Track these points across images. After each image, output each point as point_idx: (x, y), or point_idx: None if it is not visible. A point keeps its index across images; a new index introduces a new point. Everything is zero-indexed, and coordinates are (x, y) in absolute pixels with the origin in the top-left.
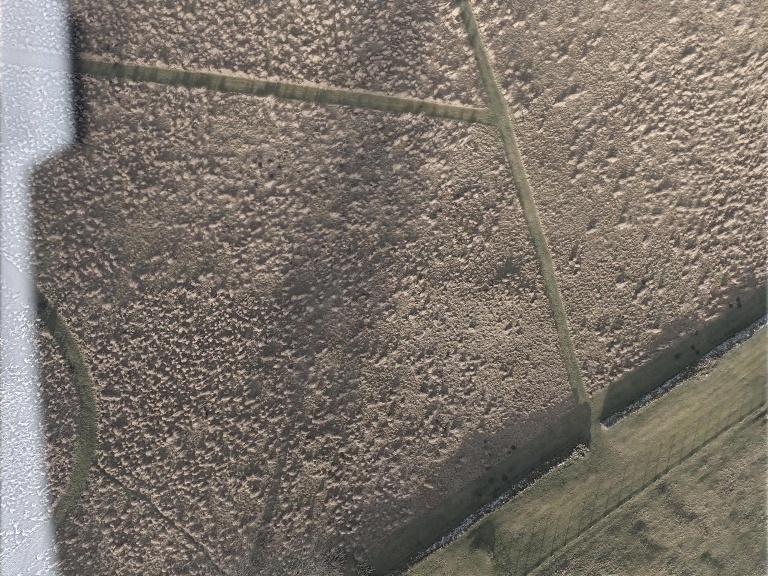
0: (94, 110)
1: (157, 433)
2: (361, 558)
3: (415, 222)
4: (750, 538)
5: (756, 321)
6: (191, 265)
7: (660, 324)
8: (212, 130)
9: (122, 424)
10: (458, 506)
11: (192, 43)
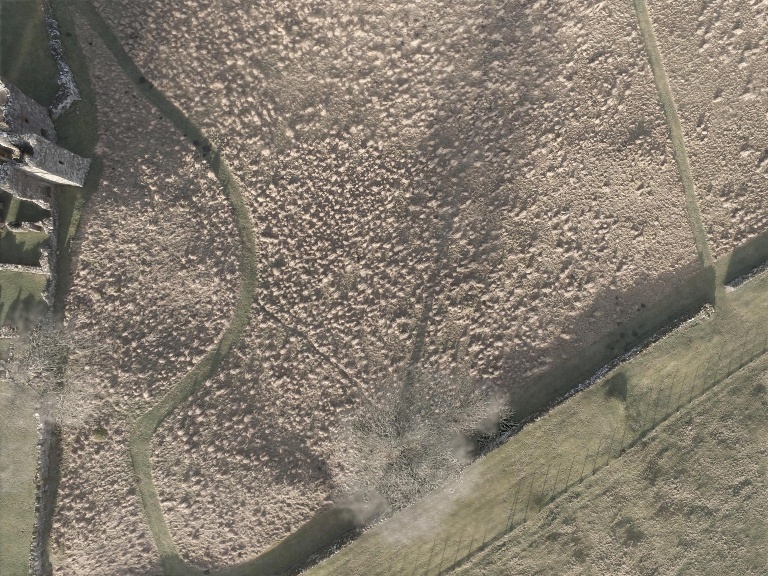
0: None
1: (313, 274)
2: (503, 400)
3: (552, 84)
4: None
5: None
6: (342, 118)
7: None
8: None
9: (280, 265)
10: (592, 358)
11: None
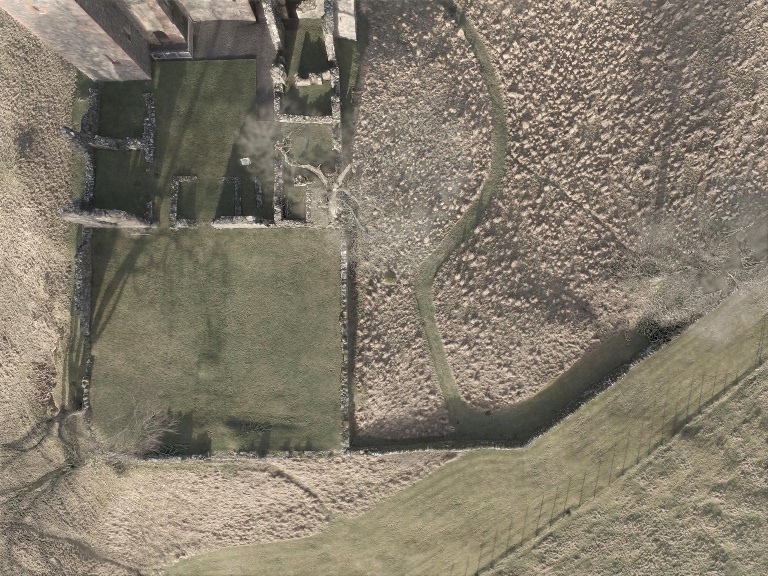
0: None
1: (558, 127)
2: (743, 240)
3: None
4: None
5: None
6: None
7: None
8: None
9: (527, 119)
10: None
11: None
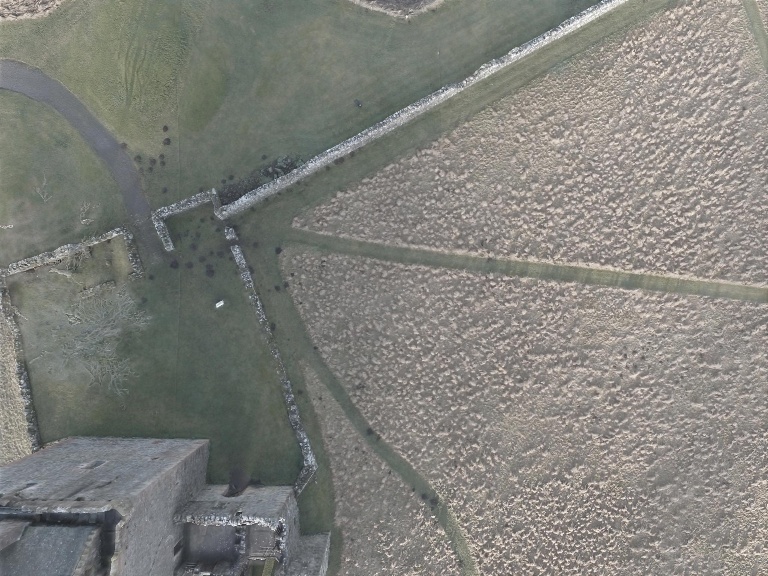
0: (471, 305)
1: None
2: None
3: None
4: None
5: None
6: (563, 457)
7: None
8: (581, 323)
9: None
10: None
11: (561, 237)
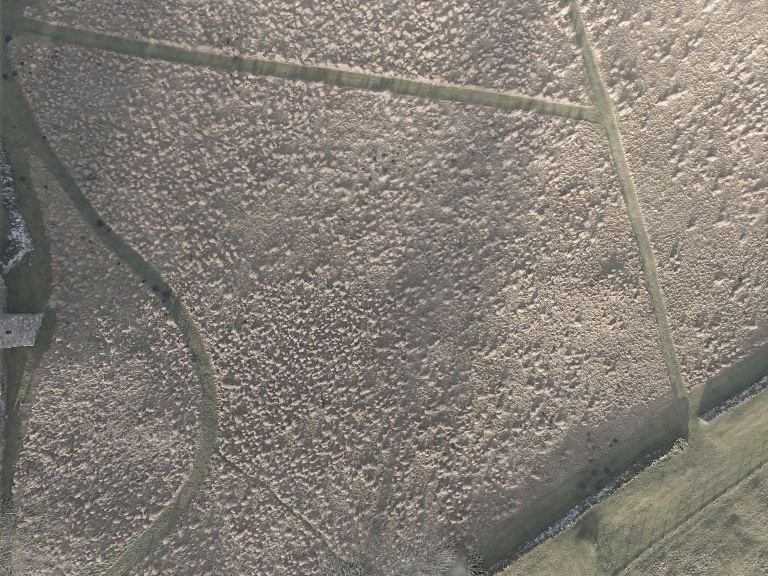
0: (215, 103)
1: (276, 421)
2: (471, 547)
3: (523, 217)
4: None
5: None
6: (308, 257)
7: (756, 321)
8: (329, 124)
9: (242, 412)
10: (563, 497)
11: (310, 38)
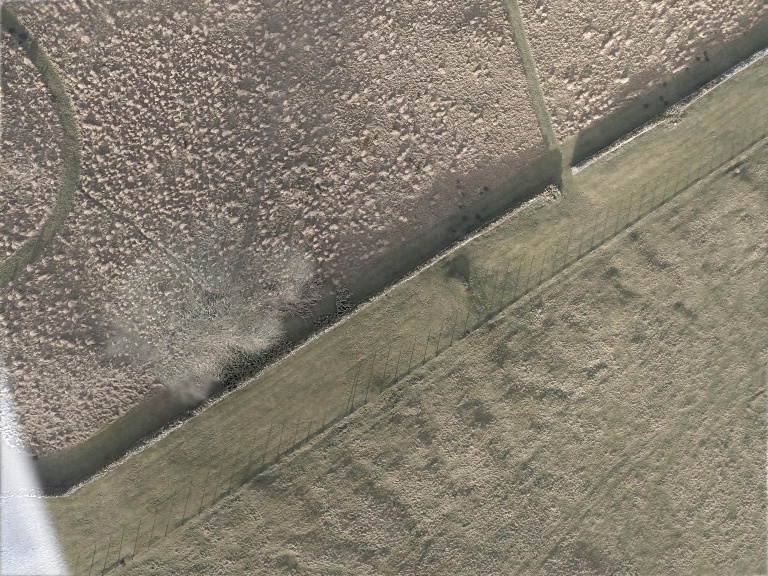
0: None
1: (138, 161)
2: (339, 283)
3: None
4: (723, 290)
5: (723, 72)
6: (166, 4)
7: (628, 75)
8: None
9: (104, 152)
10: (433, 241)
11: None
